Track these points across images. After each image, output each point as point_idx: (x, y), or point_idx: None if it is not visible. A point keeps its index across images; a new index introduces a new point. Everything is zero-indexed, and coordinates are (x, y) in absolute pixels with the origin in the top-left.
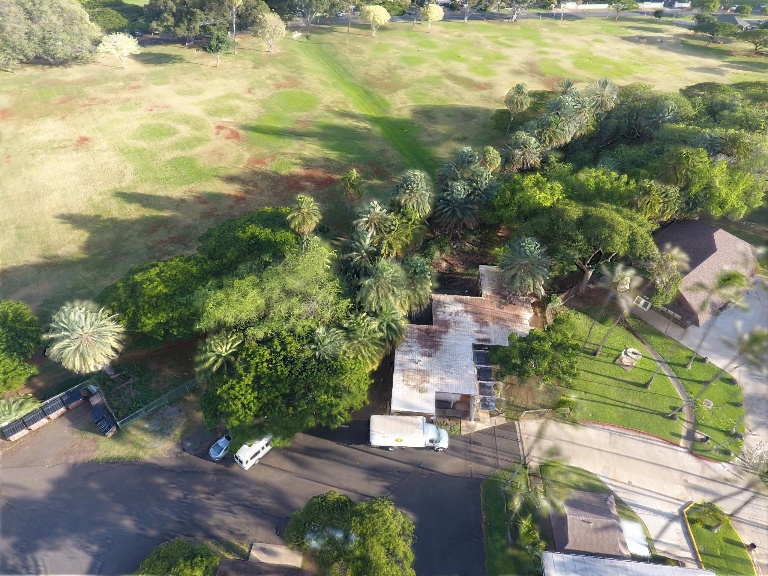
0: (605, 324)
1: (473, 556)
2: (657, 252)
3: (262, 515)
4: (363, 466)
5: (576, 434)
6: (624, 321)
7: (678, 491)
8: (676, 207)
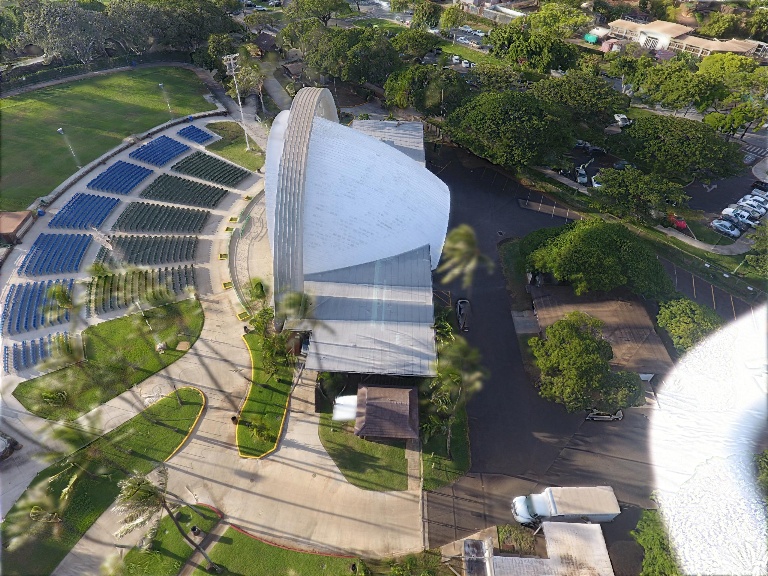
0: None
1: (476, 407)
2: None
3: (668, 430)
4: (598, 480)
5: (354, 534)
6: None
7: (268, 469)
8: None
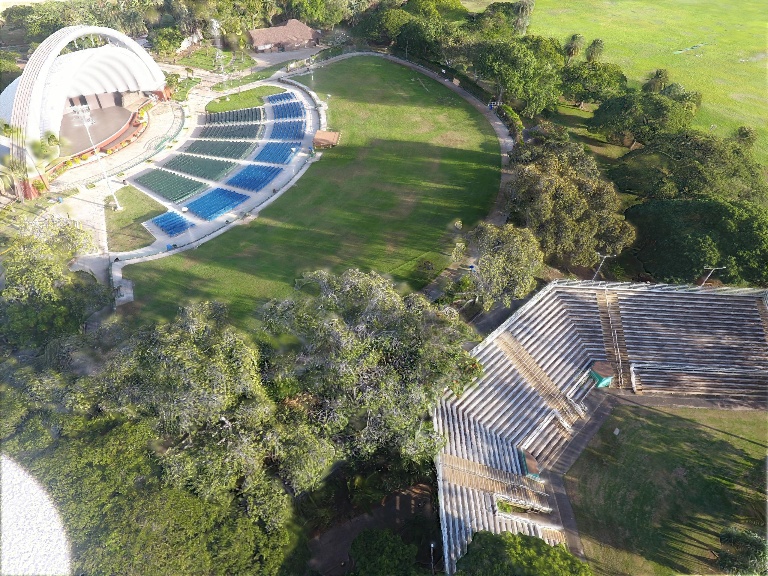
0: (224, 51)
1: None
2: (228, 8)
3: None
4: None
5: (172, 66)
6: (234, 51)
7: None
8: (273, 7)
